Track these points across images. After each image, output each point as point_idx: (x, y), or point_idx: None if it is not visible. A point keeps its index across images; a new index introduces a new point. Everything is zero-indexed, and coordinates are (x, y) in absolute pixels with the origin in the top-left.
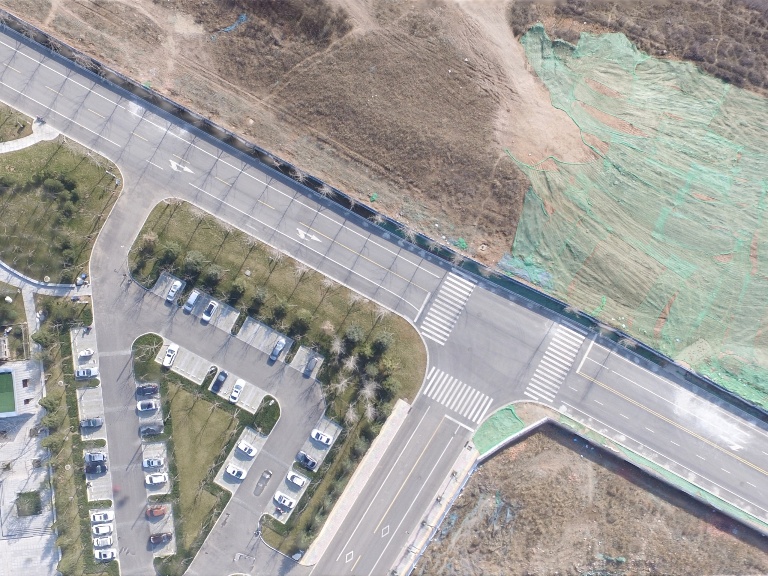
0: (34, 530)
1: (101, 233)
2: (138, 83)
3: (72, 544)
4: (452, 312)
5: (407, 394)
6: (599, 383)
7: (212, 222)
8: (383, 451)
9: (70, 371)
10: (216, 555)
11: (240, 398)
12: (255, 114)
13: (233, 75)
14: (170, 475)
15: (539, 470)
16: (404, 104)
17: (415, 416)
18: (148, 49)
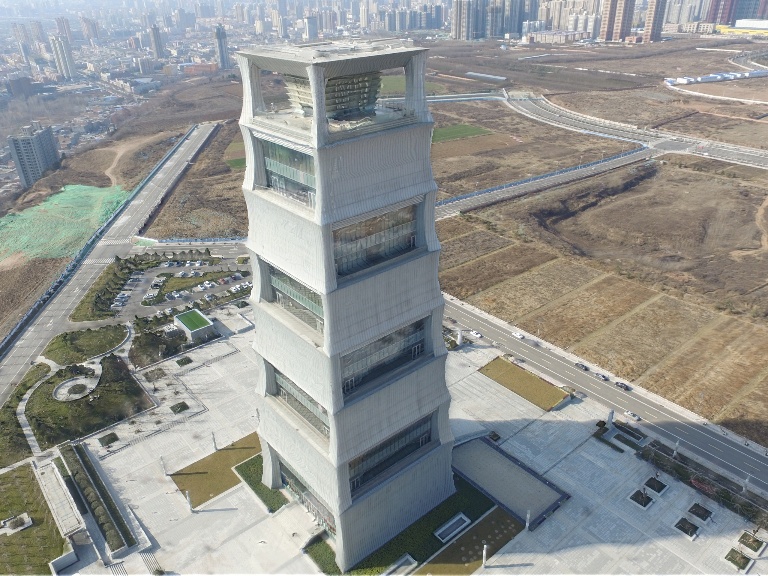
0: None
1: None
2: None
3: None
4: None
5: None
6: None
7: None
8: None
9: None
10: None
11: None
12: None
13: None
14: None
15: None
16: (4, 285)
17: None
18: None
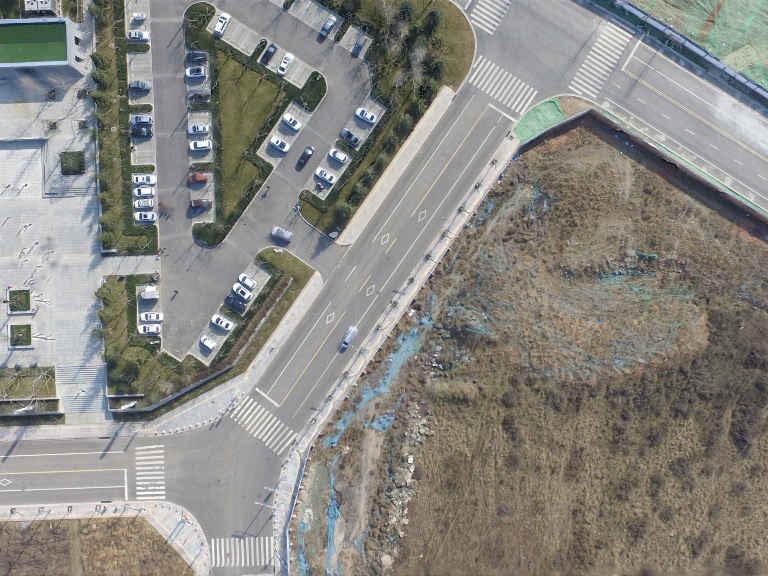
0: (76, 190)
1: None
2: None
3: (113, 205)
4: (503, 2)
5: (453, 81)
6: (643, 82)
7: None
8: (425, 137)
9: (122, 34)
10: (254, 227)
11: (288, 72)
12: None
13: None
14: (214, 143)
15: (578, 163)
16: None
17: (459, 104)
18: None
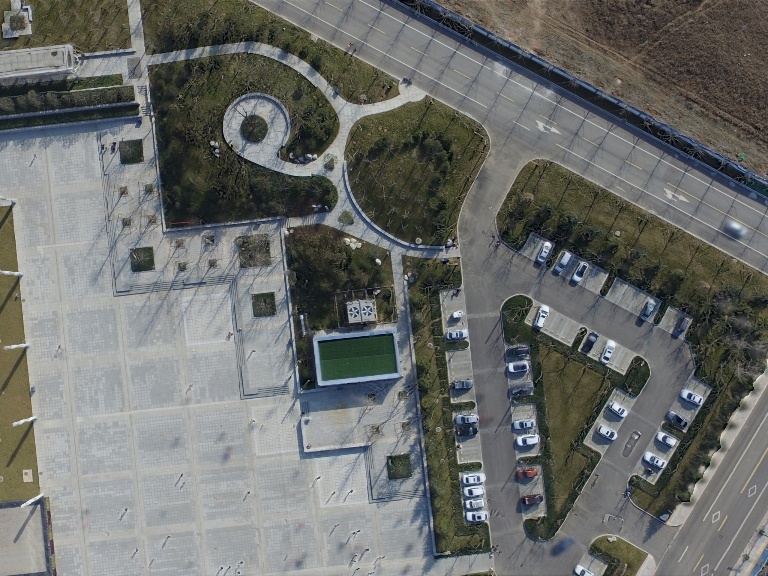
0: (404, 493)
1: (469, 195)
2: (510, 43)
3: (443, 506)
4: None
5: None
6: None
7: (580, 183)
8: (749, 411)
9: (440, 333)
10: (585, 516)
11: (610, 359)
12: (623, 74)
13: (601, 35)
14: (541, 437)
15: None
16: None
17: None
18: (514, 9)
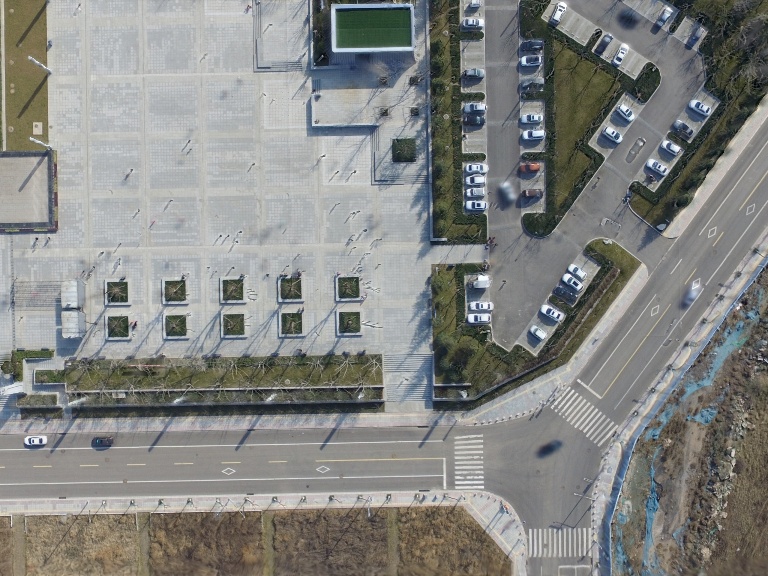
0: (407, 177)
1: None
2: None
3: (444, 193)
4: None
5: None
6: None
7: None
8: (755, 130)
9: (456, 21)
10: (583, 218)
11: (622, 62)
12: None
13: None
14: (547, 132)
15: None
16: None
17: None
18: None
